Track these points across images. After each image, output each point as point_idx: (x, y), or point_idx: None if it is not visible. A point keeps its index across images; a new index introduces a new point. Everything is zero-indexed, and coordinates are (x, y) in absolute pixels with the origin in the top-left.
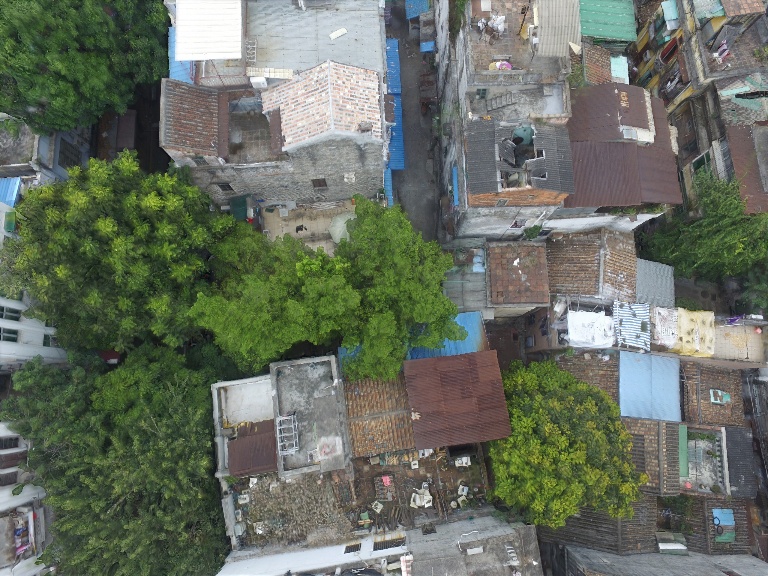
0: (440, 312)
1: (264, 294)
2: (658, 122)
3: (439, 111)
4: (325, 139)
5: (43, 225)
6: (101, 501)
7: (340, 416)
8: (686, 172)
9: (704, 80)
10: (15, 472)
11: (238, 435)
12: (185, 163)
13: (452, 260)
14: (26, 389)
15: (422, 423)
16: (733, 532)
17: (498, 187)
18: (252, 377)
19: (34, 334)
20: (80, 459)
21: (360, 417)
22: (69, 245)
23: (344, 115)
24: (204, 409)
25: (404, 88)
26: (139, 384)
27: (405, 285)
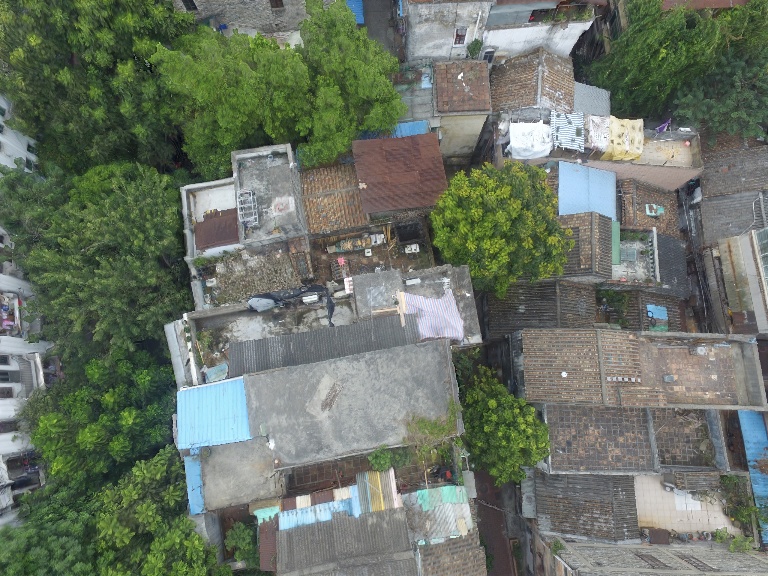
0: (382, 87)
1: (218, 55)
2: None
3: None
4: None
5: (18, 3)
6: (77, 254)
7: (294, 188)
8: (621, 5)
9: None
10: (1, 264)
11: None
12: None
13: None
14: (9, 186)
15: (369, 191)
16: (666, 325)
17: None
18: (218, 180)
19: (16, 152)
20: (58, 226)
21: (314, 194)
22: (42, 19)
23: None
24: None
25: None
26: None
27: (349, 63)
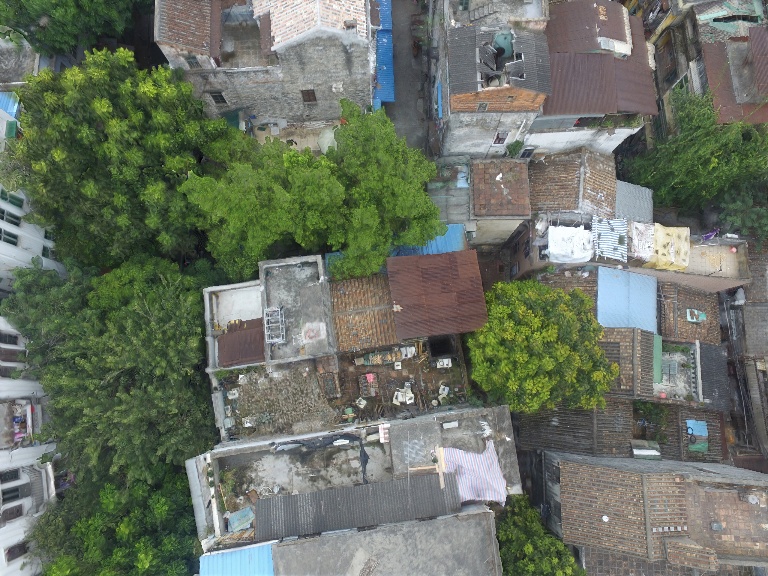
0: (421, 207)
1: (252, 178)
2: (636, 38)
3: (429, 46)
4: (312, 36)
5: (42, 114)
6: (95, 379)
7: (325, 308)
8: (666, 99)
9: (683, 5)
10: (14, 367)
11: (228, 332)
12: (179, 65)
13: (435, 167)
14: (25, 287)
15: (403, 314)
16: (706, 442)
17: (478, 87)
18: (242, 282)
19: (33, 243)
20: (76, 343)
21: (344, 312)
22: (67, 133)
23: (330, 13)
24: (196, 312)
25: (395, 25)
26: (133, 283)
27: (388, 180)
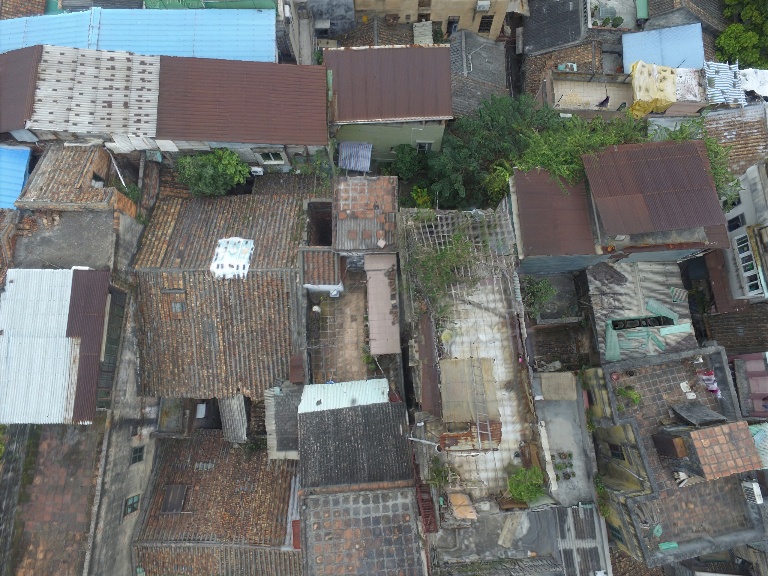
0: None
1: None
2: None
3: None
4: None
5: None
6: None
7: None
8: None
9: None
10: None
11: None
12: None
13: None
14: None
15: None
16: None
17: None
18: None
19: None
20: None
21: None
22: None
23: None
24: None
25: None
26: None
27: None
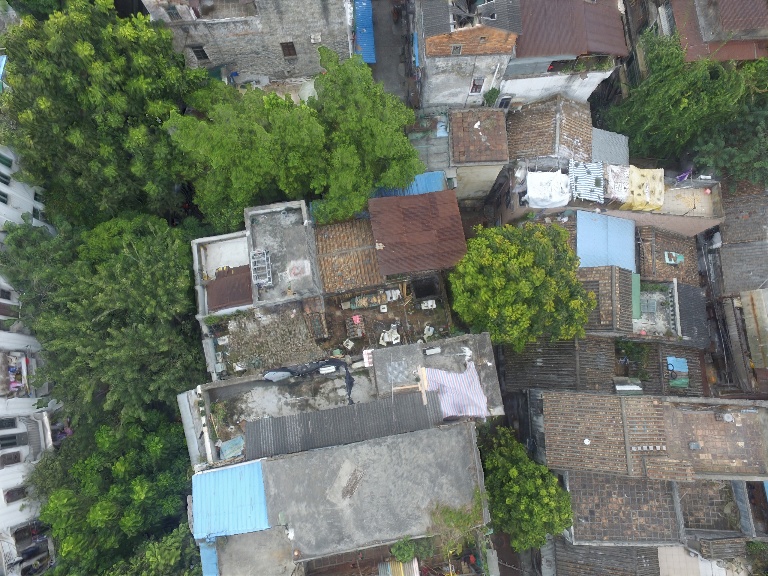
0: (399, 146)
1: (233, 118)
2: None
3: None
4: None
5: (27, 63)
6: (87, 321)
7: (309, 248)
8: None
9: None
10: None
11: (216, 278)
12: (159, 16)
13: (413, 112)
14: (16, 242)
15: (386, 252)
16: (687, 378)
17: (451, 28)
18: (229, 233)
19: (23, 203)
20: (67, 289)
21: (329, 253)
22: (51, 81)
23: None
24: (185, 263)
25: None
26: (122, 235)
27: (366, 121)
